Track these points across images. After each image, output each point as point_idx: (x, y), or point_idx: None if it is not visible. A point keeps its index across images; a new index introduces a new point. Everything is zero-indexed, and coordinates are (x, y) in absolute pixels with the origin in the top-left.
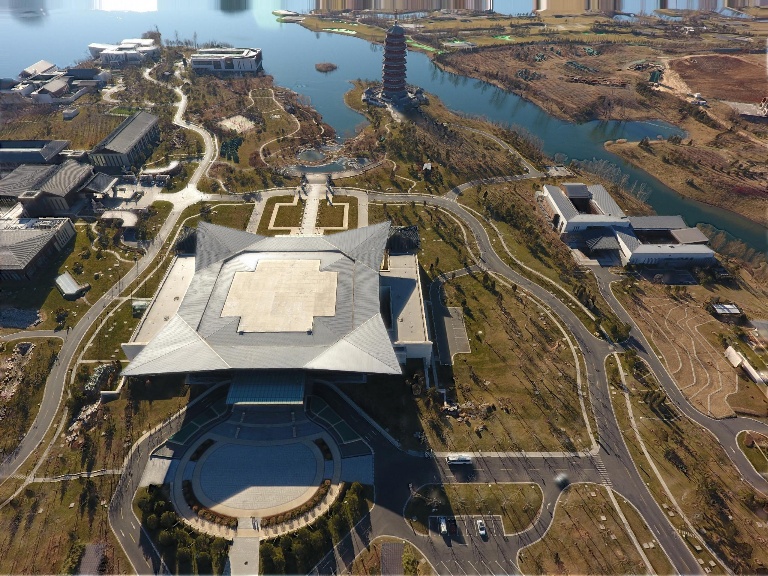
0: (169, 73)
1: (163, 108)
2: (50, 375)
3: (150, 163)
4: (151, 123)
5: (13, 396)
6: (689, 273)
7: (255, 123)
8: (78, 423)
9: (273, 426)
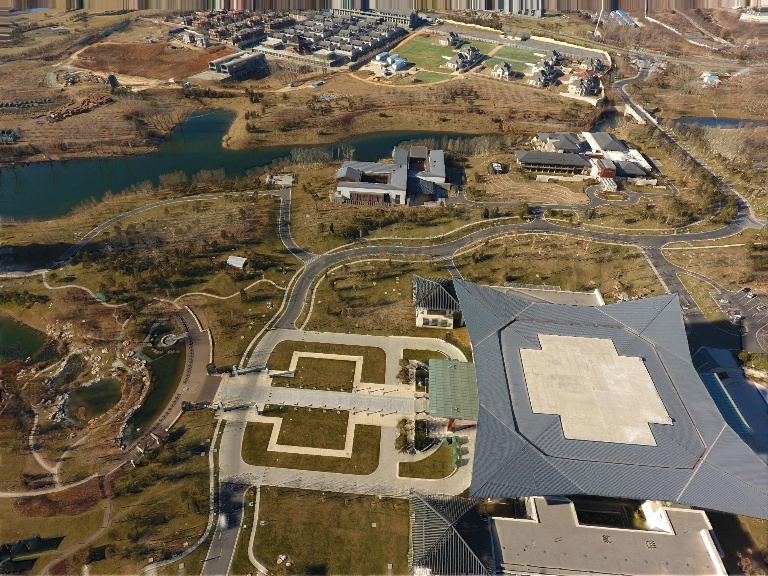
0: None
1: None
2: None
3: None
4: None
5: None
6: (454, 168)
7: None
8: None
9: None
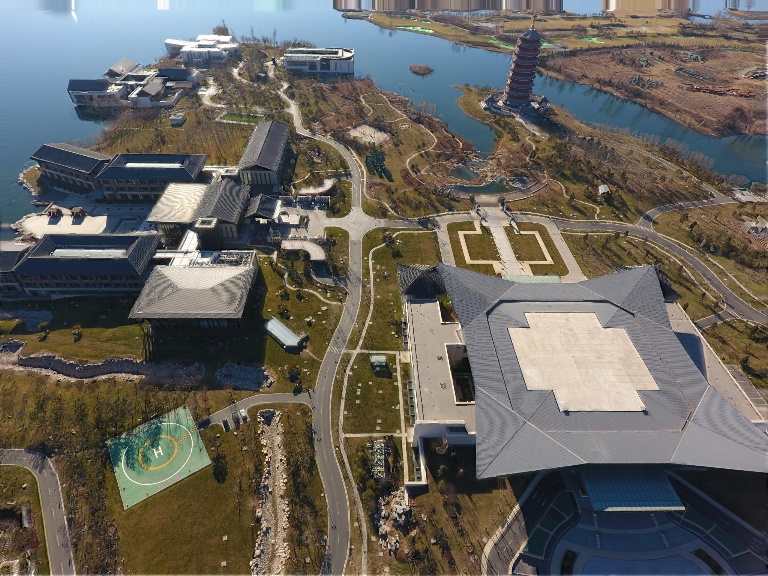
0: (264, 74)
1: (277, 115)
2: (317, 454)
3: (298, 181)
4: (286, 134)
5: (287, 483)
6: None
7: (391, 135)
8: (385, 522)
9: (636, 532)
